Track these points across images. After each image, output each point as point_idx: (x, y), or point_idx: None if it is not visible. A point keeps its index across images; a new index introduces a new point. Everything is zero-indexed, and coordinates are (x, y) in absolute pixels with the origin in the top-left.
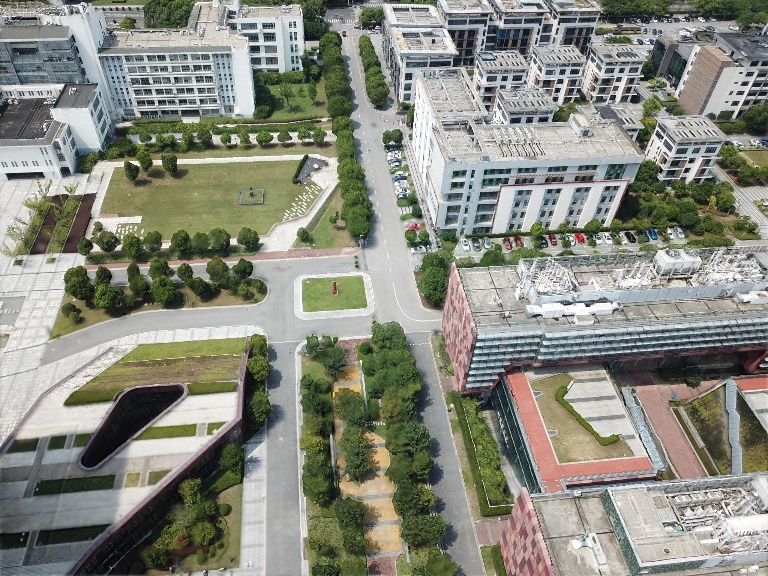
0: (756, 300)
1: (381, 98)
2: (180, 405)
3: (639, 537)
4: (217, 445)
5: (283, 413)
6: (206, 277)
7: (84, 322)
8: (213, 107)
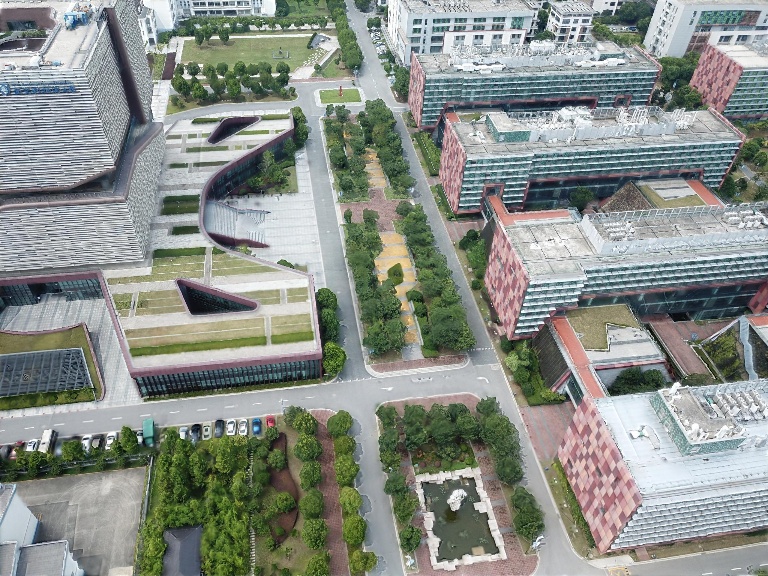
0: (584, 64)
1: (365, 3)
2: (258, 124)
3: (500, 126)
4: (281, 140)
5: (315, 142)
6: None
7: (186, 108)
8: (246, 8)
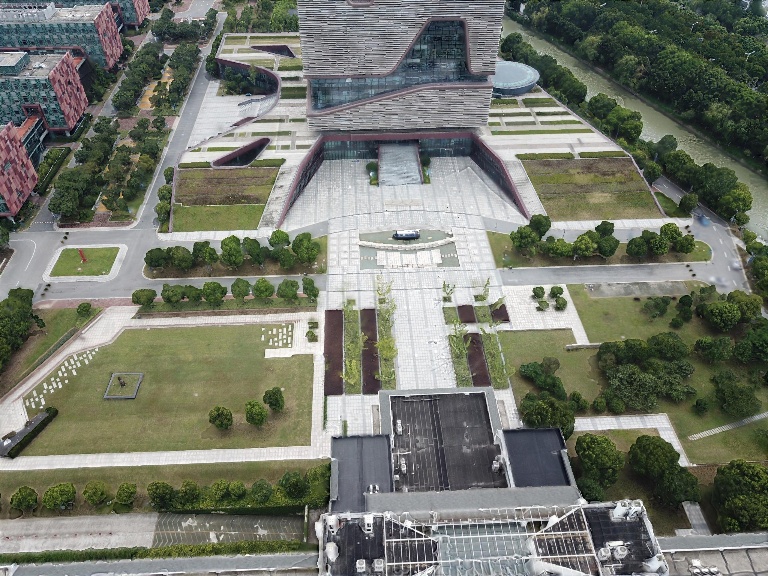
0: None
1: None
2: None
3: None
4: None
5: None
6: (198, 282)
7: None
8: None
